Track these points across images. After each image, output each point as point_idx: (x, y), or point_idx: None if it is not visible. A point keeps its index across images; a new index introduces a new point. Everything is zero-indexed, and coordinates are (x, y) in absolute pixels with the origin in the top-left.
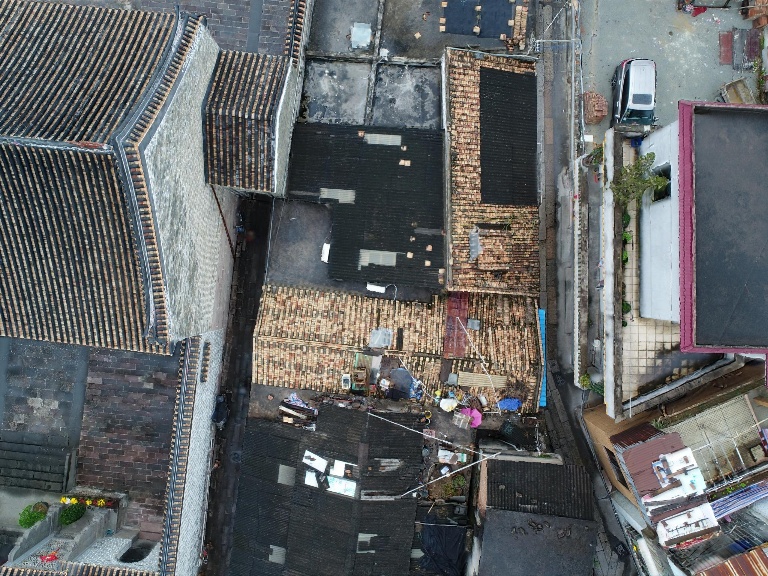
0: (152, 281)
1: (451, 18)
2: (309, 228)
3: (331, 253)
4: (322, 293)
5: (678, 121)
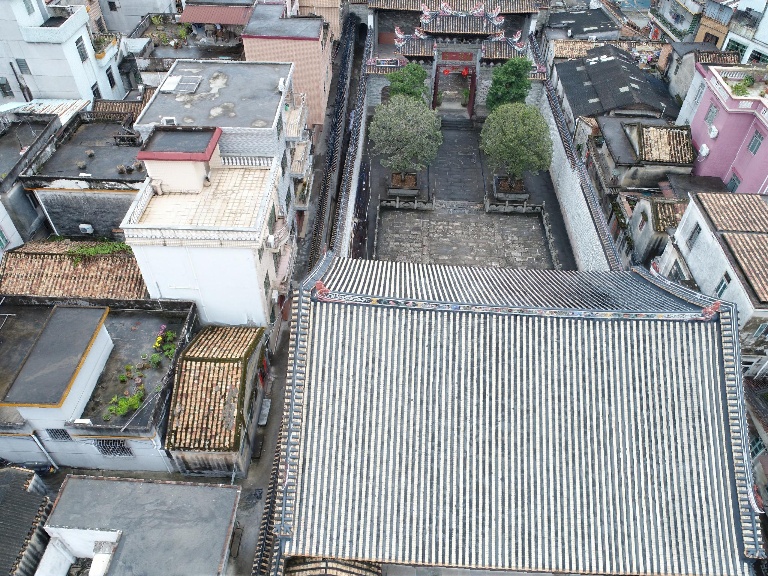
0: None
1: (587, 3)
2: (559, 32)
3: None
4: None
5: None
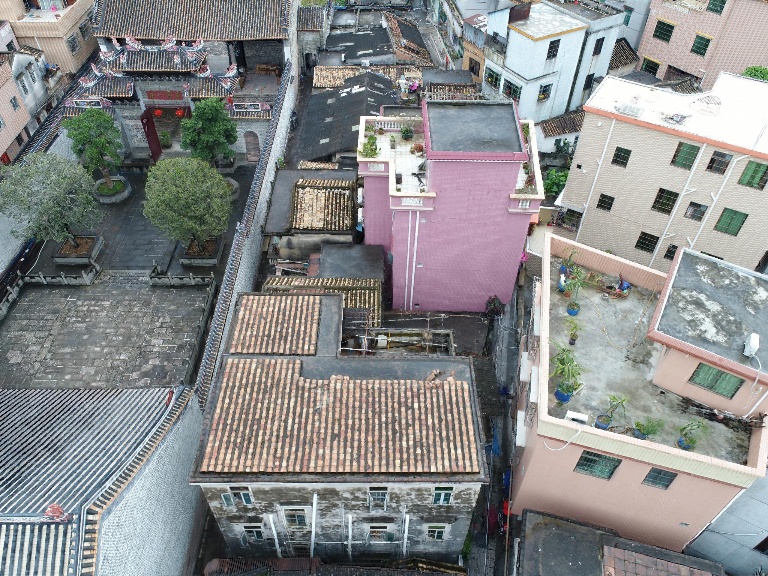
0: (287, 3)
1: None
2: (335, 56)
3: (345, 55)
4: (342, 66)
5: None
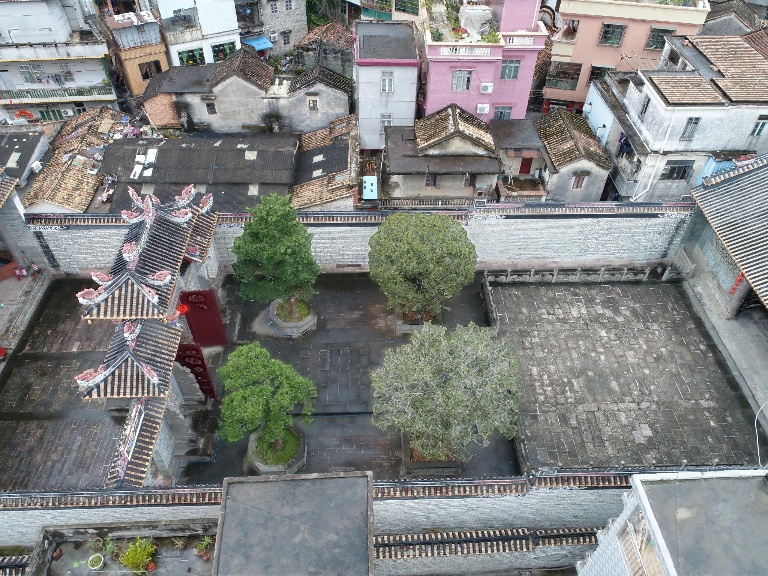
0: None
1: None
2: None
3: None
4: None
5: None
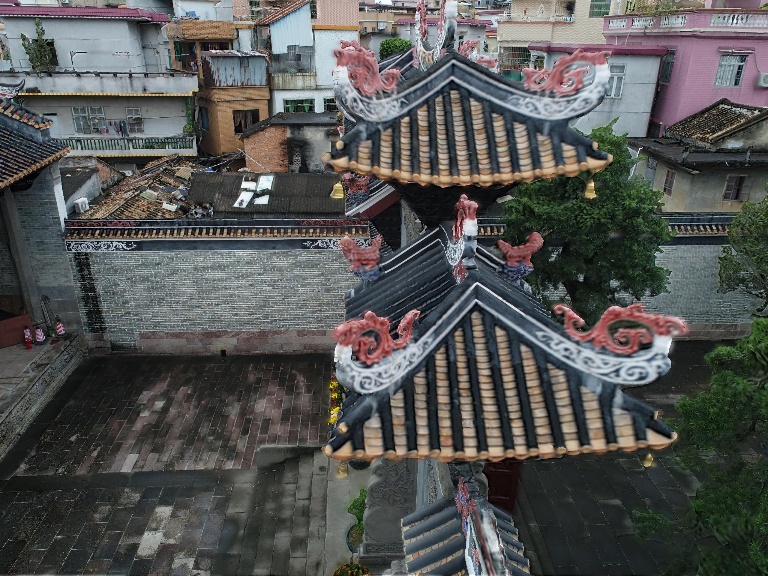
0: None
1: None
2: None
3: None
4: None
5: (6, 25)
